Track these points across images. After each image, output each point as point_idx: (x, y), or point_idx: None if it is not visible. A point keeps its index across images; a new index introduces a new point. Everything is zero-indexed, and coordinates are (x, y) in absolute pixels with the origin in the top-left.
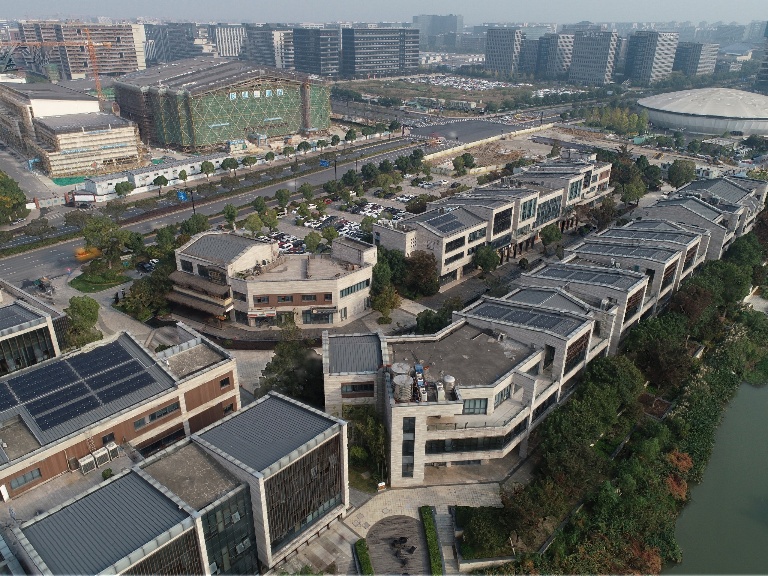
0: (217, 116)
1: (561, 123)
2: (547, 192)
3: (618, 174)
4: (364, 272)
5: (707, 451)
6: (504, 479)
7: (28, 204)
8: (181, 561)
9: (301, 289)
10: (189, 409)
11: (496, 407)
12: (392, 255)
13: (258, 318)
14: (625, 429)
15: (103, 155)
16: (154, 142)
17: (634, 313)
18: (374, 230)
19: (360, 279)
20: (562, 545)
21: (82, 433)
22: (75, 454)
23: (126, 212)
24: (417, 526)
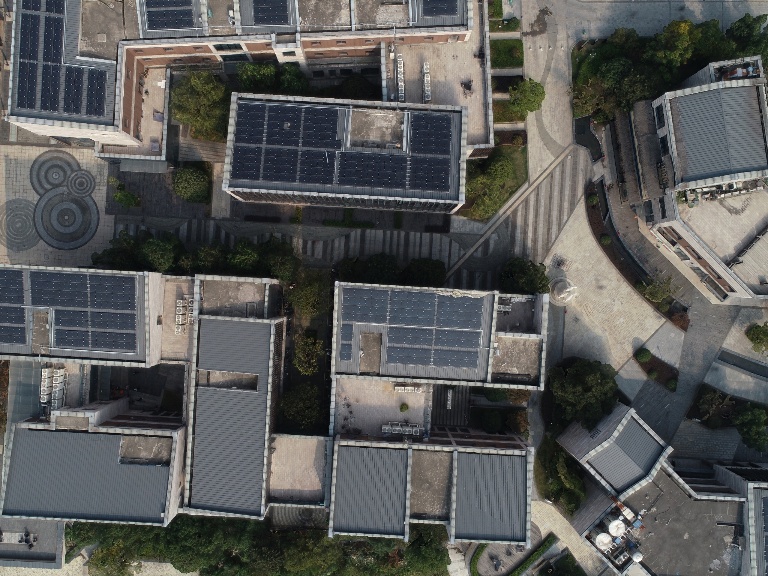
0: None
1: None
2: None
3: None
4: None
5: None
6: None
7: None
8: None
9: (715, 266)
10: None
11: None
12: None
13: None
14: None
15: None
16: None
17: None
18: None
19: None
20: None
21: None
22: None
23: None
24: (537, 541)
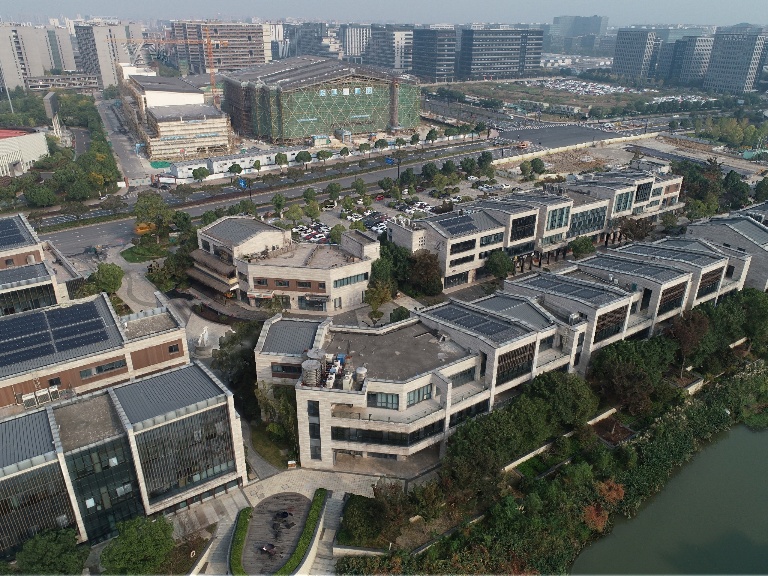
0: (306, 111)
1: (667, 132)
2: (589, 202)
3: (695, 189)
4: (362, 265)
5: (651, 487)
6: (413, 478)
7: (119, 182)
8: (46, 488)
9: (297, 275)
10: (136, 368)
11: (412, 405)
12: (398, 252)
13: (257, 299)
14: (563, 450)
15: (197, 143)
16: (250, 133)
17: (615, 333)
18: (388, 226)
19: (357, 272)
20: (432, 548)
21: (29, 373)
22: (23, 390)
23: (197, 195)
24: (306, 505)
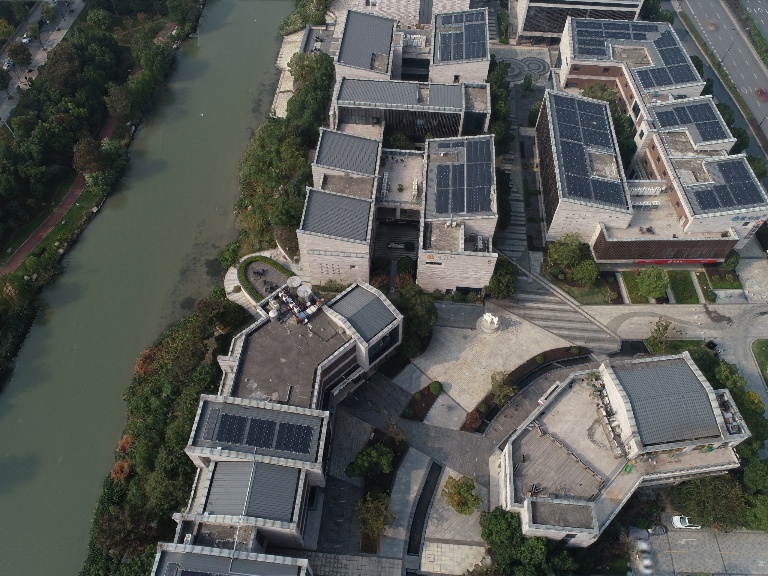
0: None
1: None
2: None
3: None
4: None
5: None
6: None
7: None
8: None
9: None
10: None
11: None
12: (528, 570)
13: None
14: None
15: None
16: None
17: None
18: None
19: None
20: None
21: None
22: None
23: None
24: None
